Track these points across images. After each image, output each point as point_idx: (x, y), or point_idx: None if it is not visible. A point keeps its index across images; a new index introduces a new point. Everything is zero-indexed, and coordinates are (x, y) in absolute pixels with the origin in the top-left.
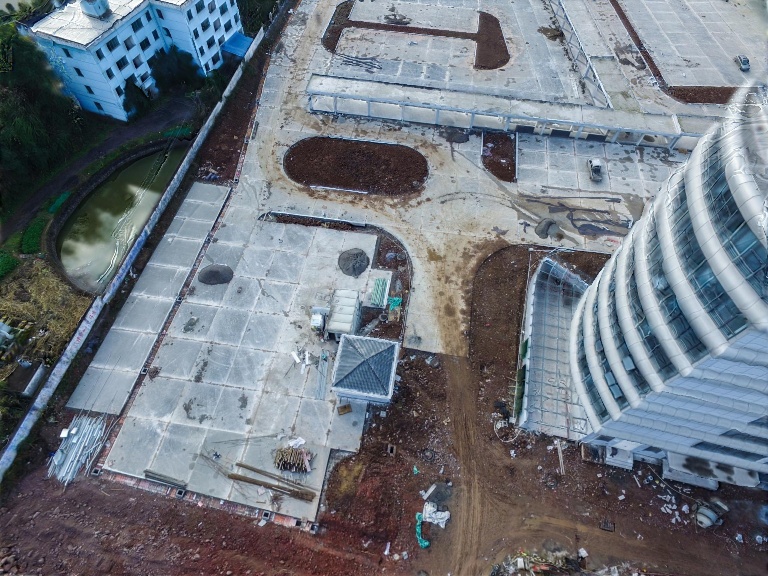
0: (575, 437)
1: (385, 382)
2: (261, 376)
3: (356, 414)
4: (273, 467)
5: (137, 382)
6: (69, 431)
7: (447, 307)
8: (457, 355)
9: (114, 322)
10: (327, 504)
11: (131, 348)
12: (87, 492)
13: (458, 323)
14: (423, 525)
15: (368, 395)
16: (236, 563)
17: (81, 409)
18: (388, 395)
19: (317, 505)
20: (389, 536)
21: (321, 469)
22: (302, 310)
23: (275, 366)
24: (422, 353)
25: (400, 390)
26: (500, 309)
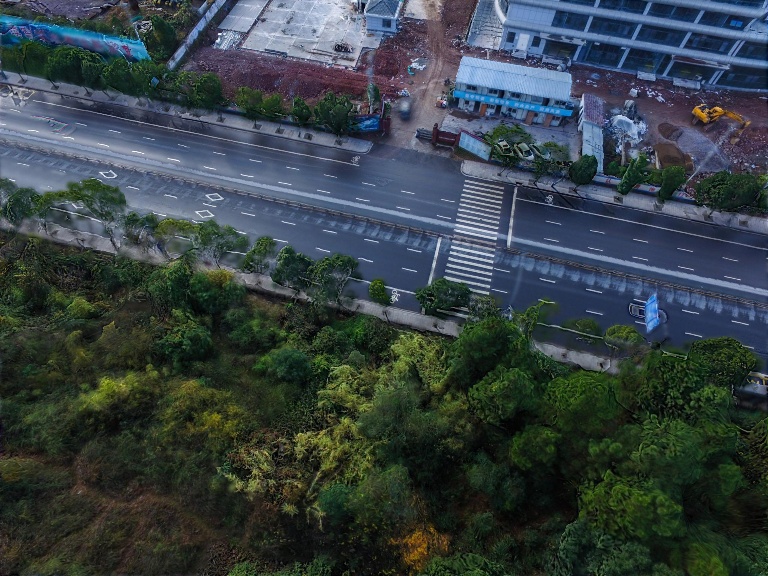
0: (497, 48)
1: (393, 11)
2: (323, 23)
3: (377, 37)
4: (332, 50)
5: (254, 23)
6: (222, 33)
7: (431, 4)
8: (435, 20)
9: (237, 2)
10: (361, 62)
11: (249, 11)
12: (235, 53)
13: (436, 9)
14: (411, 69)
15: (384, 16)
16: (316, 71)
17: (226, 29)
18: (395, 17)
19: (356, 62)
20: (393, 73)
21: (358, 52)
22: (345, 3)
23: (331, 20)
24: (415, 20)
25: (401, 31)
26: (462, 5)
